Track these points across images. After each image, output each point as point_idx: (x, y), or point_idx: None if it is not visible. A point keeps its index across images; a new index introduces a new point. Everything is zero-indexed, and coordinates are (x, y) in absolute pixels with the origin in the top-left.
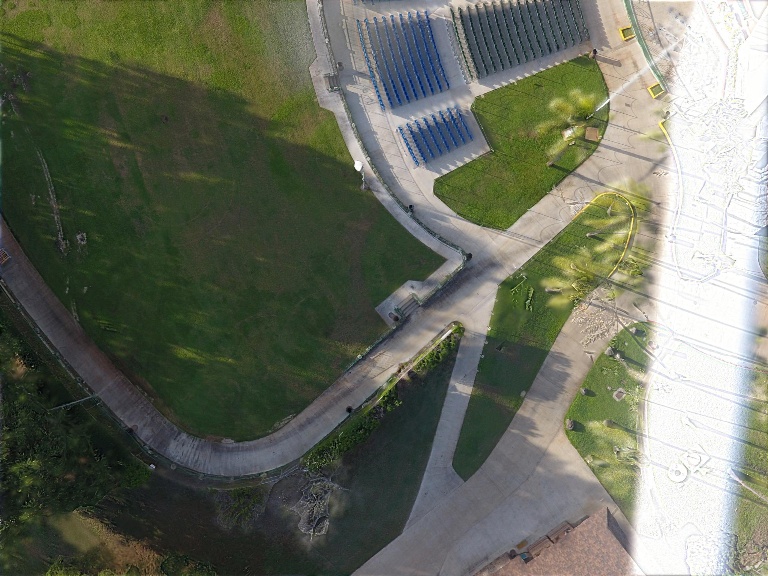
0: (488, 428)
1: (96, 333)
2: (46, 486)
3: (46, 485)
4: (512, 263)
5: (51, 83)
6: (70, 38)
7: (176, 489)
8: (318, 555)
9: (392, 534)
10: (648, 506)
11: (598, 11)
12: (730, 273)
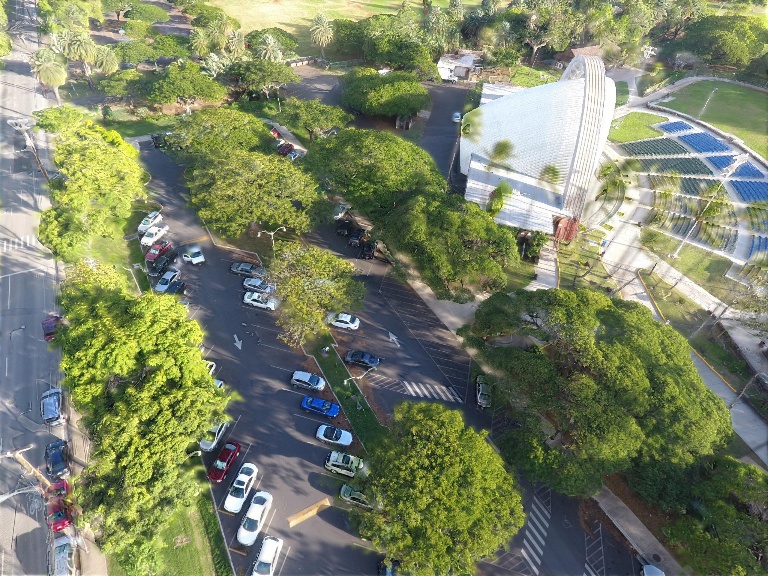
0: None
1: None
2: (767, 53)
3: (767, 53)
4: (626, 106)
5: None
6: None
7: None
8: None
9: None
10: None
11: None
12: None
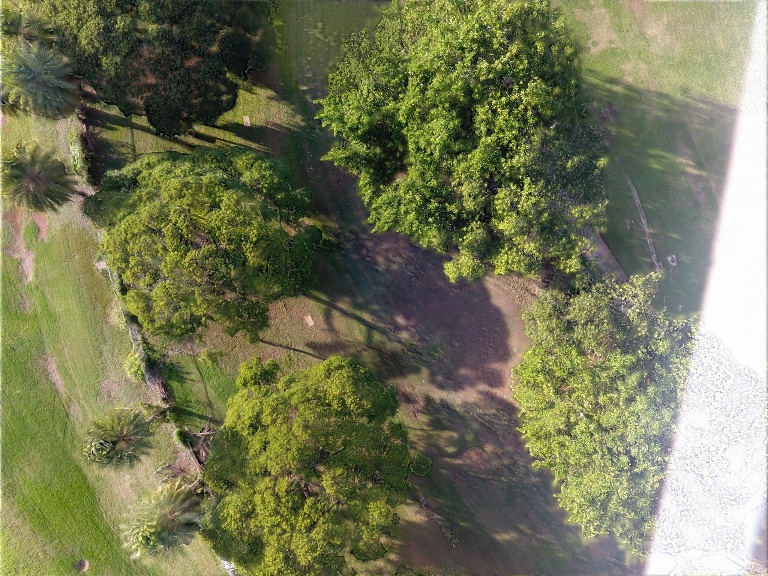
0: None
1: None
2: None
3: None
4: None
5: (634, 115)
6: (646, 73)
7: None
8: None
9: None
10: None
11: None
12: None
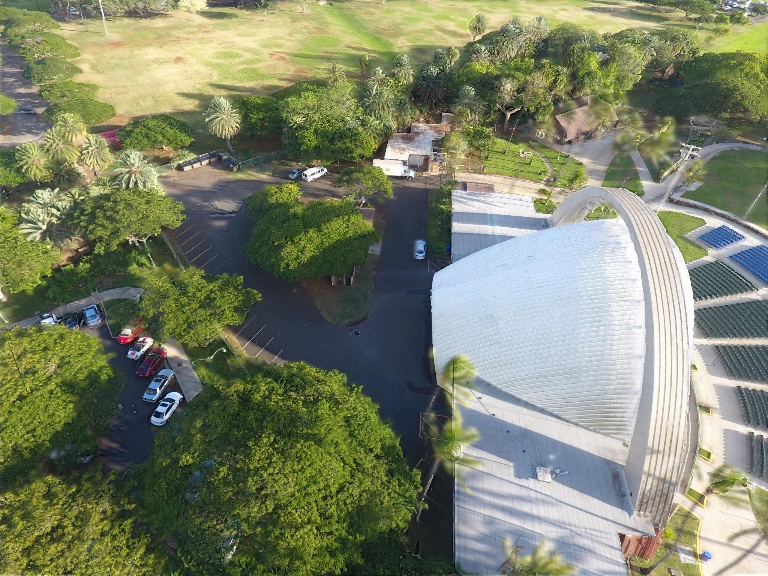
0: None
1: None
2: None
3: None
4: None
5: None
6: None
7: None
8: None
9: None
10: (536, 148)
11: None
12: None
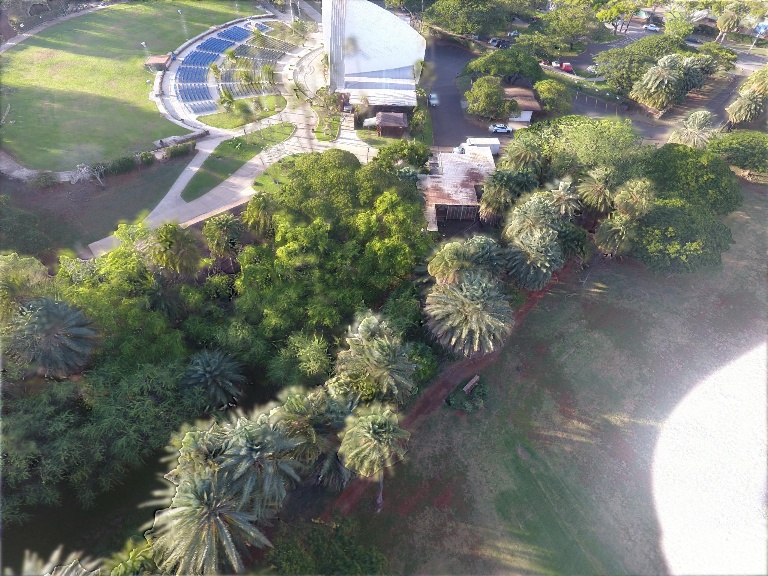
0: (206, 183)
1: None
2: None
3: None
4: None
5: (28, 91)
6: None
7: (6, 192)
8: (81, 226)
9: (134, 223)
10: None
11: (284, 86)
12: (343, 139)
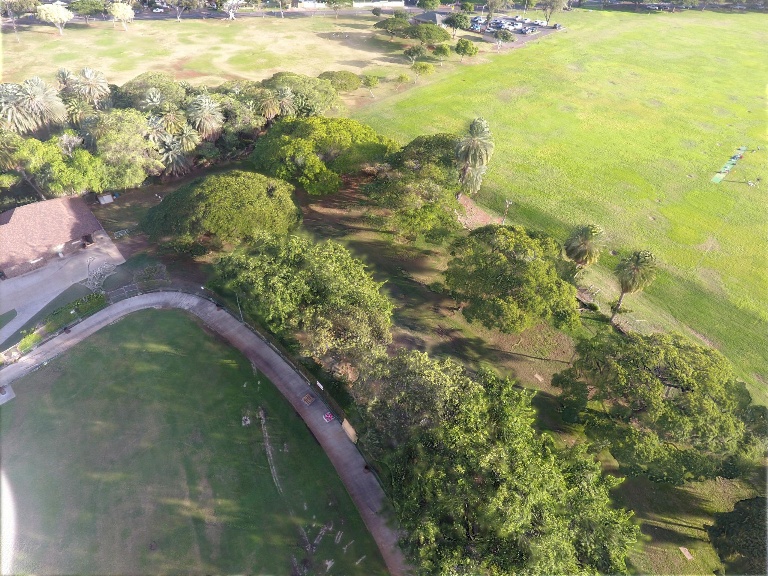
0: None
1: (239, 357)
2: None
3: None
4: None
5: (267, 571)
6: None
7: None
8: (129, 270)
9: None
10: None
11: None
12: None
